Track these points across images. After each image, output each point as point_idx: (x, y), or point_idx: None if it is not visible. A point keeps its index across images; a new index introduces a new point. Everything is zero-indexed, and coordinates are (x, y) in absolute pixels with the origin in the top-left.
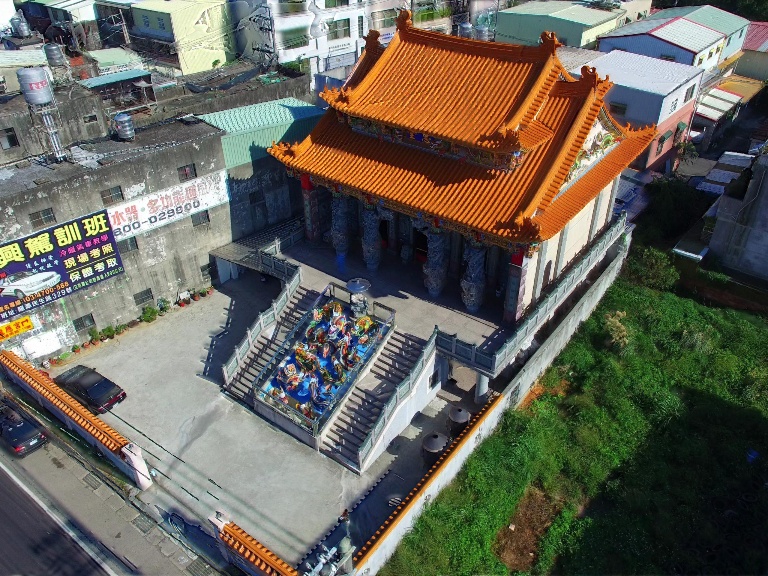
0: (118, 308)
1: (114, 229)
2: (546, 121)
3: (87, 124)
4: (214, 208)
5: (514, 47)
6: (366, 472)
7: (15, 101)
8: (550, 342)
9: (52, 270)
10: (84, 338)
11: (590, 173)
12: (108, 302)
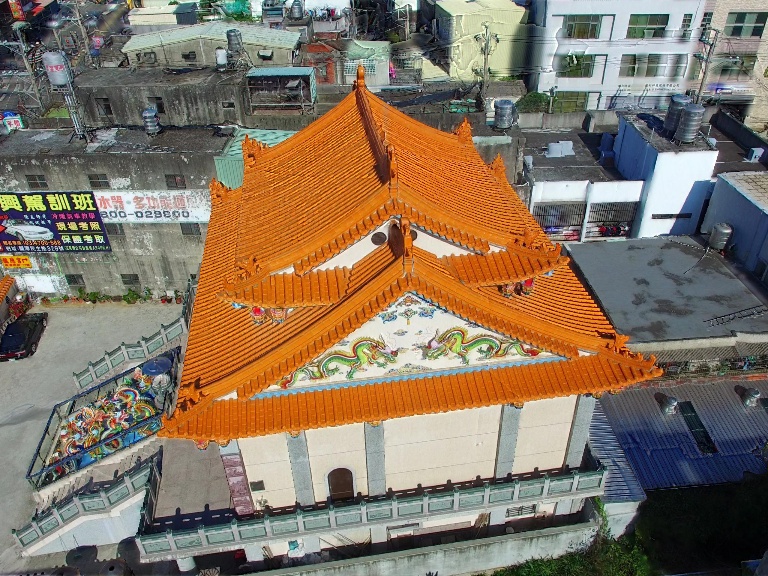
0: (106, 280)
1: (101, 211)
2: (355, 276)
3: (225, 109)
4: (206, 224)
5: (381, 154)
6: (30, 557)
7: (186, 75)
8: (308, 571)
9: (47, 227)
10: (76, 292)
11: (430, 381)
12: (97, 271)
